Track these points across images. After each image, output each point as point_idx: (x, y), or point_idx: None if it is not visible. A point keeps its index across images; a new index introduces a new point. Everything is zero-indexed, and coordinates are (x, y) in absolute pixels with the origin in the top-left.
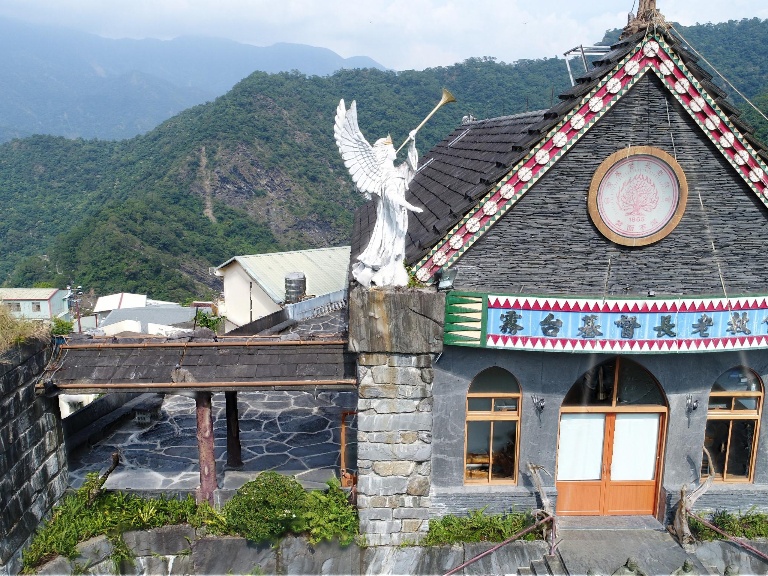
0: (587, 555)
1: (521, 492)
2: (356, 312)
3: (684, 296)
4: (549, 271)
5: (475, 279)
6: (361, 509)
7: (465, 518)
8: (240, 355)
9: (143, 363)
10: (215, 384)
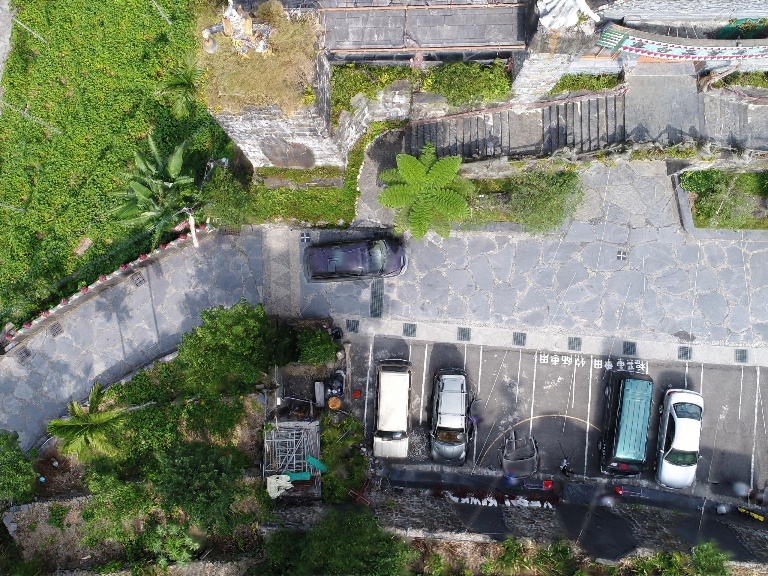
0: (640, 101)
1: (614, 67)
2: (536, 42)
3: (762, 44)
4: (682, 4)
5: (626, 8)
6: (514, 85)
7: (575, 75)
8: (445, 16)
9: (380, 25)
10: (433, 49)
